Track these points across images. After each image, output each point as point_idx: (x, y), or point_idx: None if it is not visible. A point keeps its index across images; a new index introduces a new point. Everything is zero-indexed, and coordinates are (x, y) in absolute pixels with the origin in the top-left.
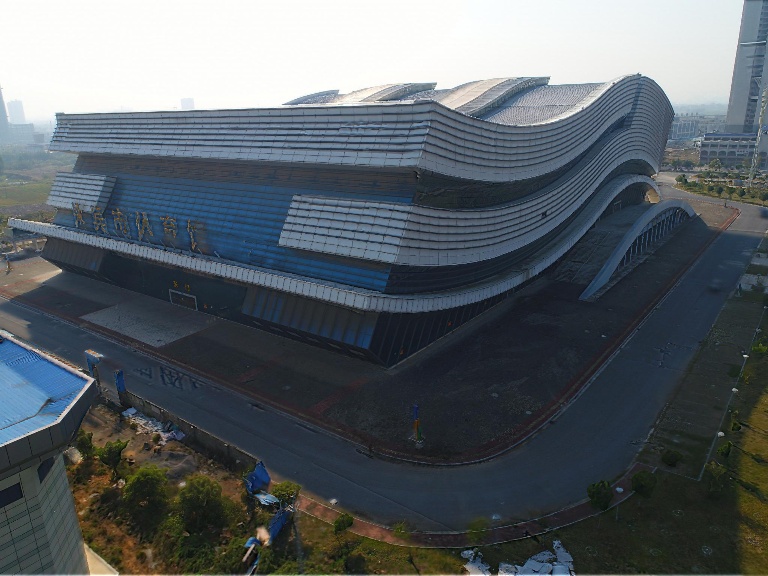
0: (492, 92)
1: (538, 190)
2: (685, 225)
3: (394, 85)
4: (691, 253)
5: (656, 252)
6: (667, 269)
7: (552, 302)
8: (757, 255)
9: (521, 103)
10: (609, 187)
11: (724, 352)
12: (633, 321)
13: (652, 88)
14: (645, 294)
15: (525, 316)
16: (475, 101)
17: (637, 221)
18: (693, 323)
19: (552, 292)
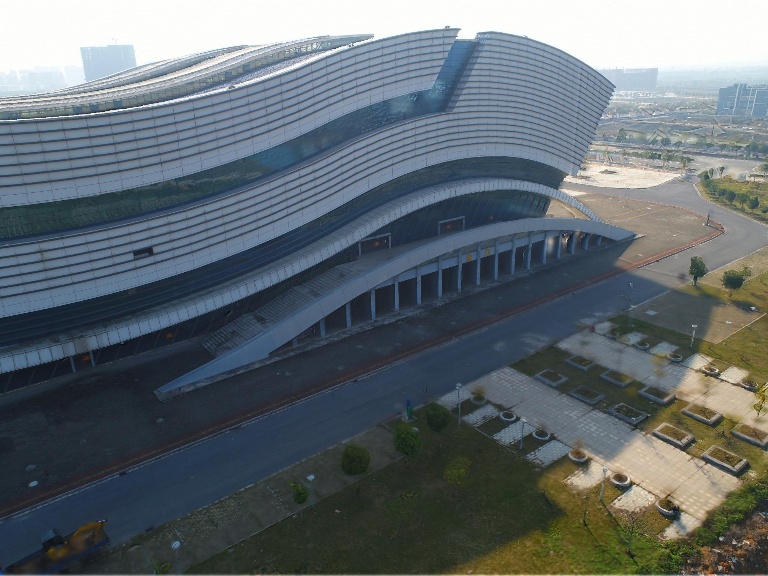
0: (234, 59)
1: (140, 215)
2: (581, 255)
3: (214, 49)
4: (497, 311)
5: (445, 305)
6: (400, 342)
7: (106, 392)
8: (590, 328)
9: (248, 76)
10: (398, 201)
11: (125, 571)
12: (143, 454)
13: (524, 50)
14: (272, 393)
15: (14, 417)
16: (195, 73)
17: (390, 260)
18: (223, 476)
19: (150, 370)
